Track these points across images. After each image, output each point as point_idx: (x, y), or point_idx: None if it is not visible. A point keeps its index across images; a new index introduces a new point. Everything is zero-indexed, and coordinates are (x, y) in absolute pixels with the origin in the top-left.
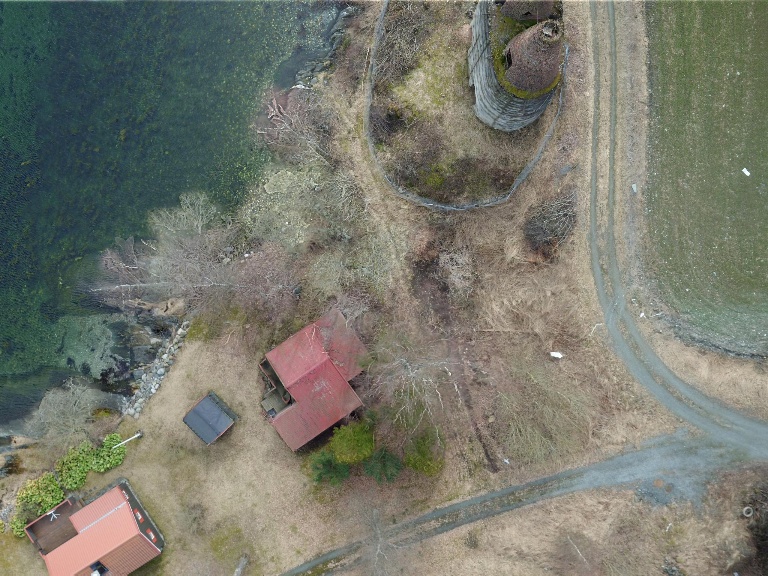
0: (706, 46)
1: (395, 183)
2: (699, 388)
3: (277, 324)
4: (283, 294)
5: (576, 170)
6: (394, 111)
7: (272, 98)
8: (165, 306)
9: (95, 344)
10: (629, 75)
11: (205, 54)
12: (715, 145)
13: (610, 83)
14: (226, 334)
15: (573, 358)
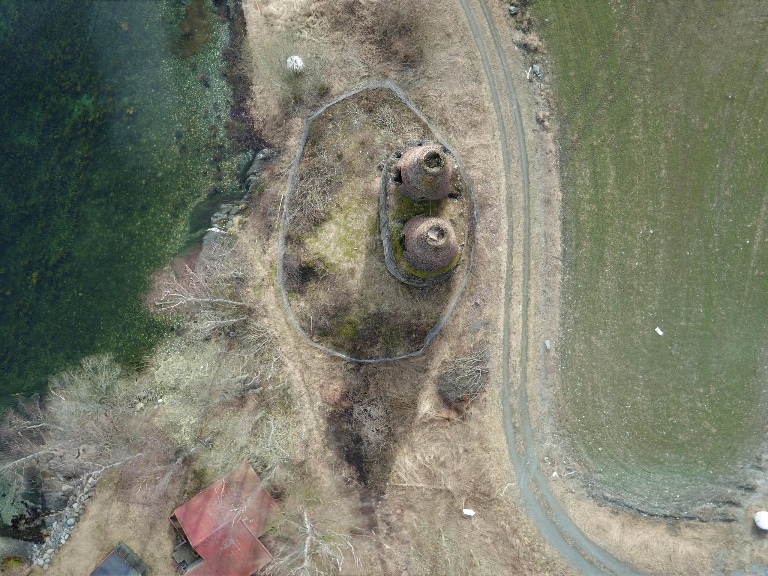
0: (619, 203)
1: (309, 332)
2: (610, 551)
3: (189, 473)
4: (196, 442)
5: (489, 326)
6: (306, 263)
7: (187, 240)
8: (77, 452)
9: (6, 489)
10: (543, 229)
11: (120, 195)
12: (628, 303)
13: (523, 238)
14: (137, 483)
15: (485, 516)
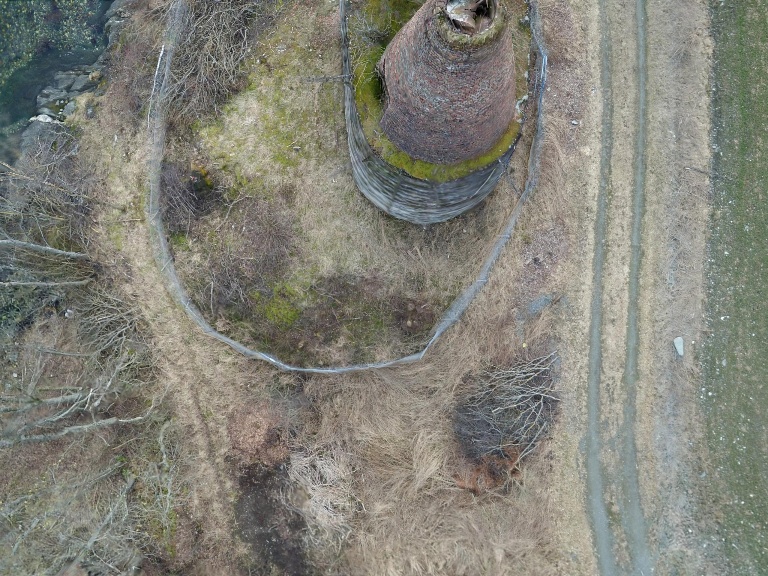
0: None
1: (208, 312)
2: None
3: None
4: None
5: (560, 306)
6: (198, 176)
7: None
8: None
9: None
10: (672, 114)
11: None
12: None
13: (633, 129)
14: None
15: None
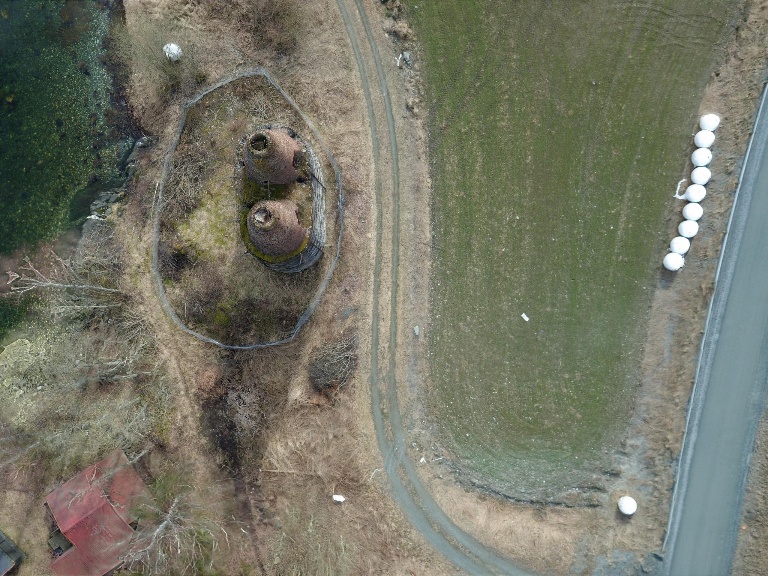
0: (486, 189)
1: (184, 319)
2: (476, 536)
3: (66, 460)
4: (73, 429)
5: (358, 312)
6: (177, 250)
7: (68, 228)
8: None
9: None
10: (412, 216)
11: (1, 182)
12: (495, 289)
13: (393, 224)
14: (14, 470)
15: (355, 502)
